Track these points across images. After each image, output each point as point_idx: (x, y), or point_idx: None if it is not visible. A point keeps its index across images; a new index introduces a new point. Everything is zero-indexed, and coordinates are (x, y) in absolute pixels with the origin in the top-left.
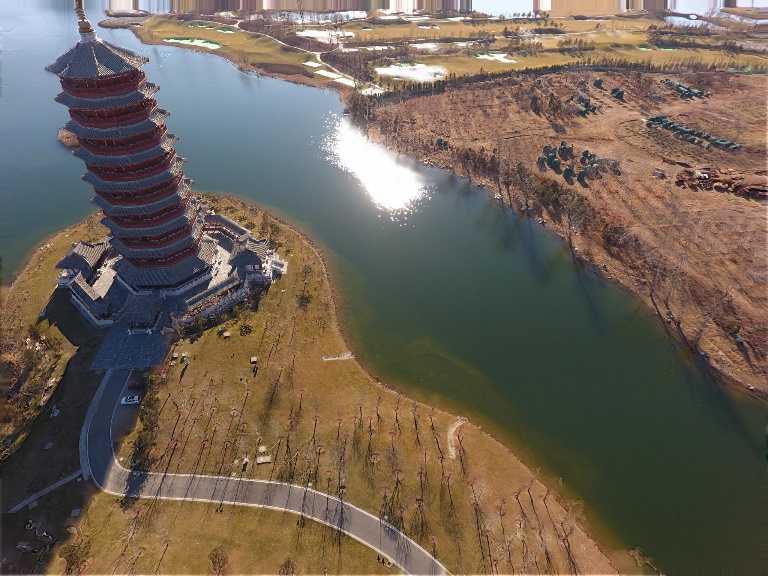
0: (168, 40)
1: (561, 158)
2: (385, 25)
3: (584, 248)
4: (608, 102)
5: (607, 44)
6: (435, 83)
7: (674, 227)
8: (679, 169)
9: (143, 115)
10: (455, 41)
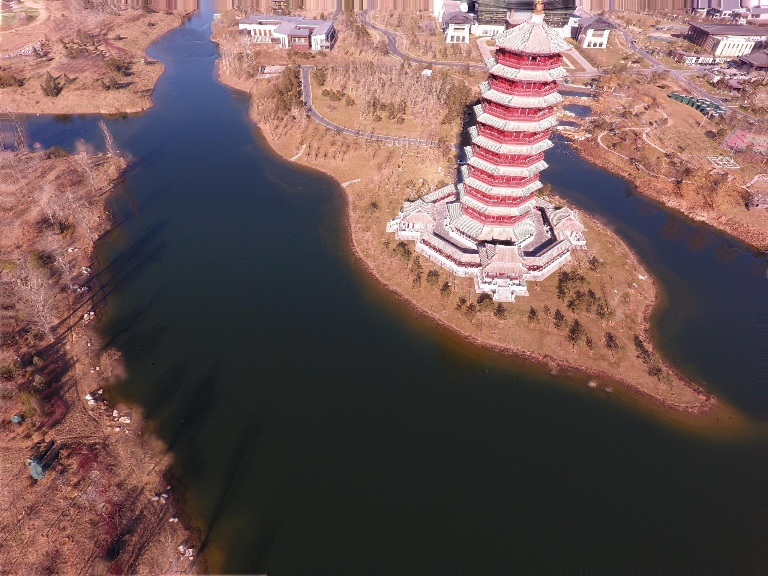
0: None
1: None
2: None
3: (90, 234)
4: None
5: None
6: None
7: None
8: None
9: None
10: None
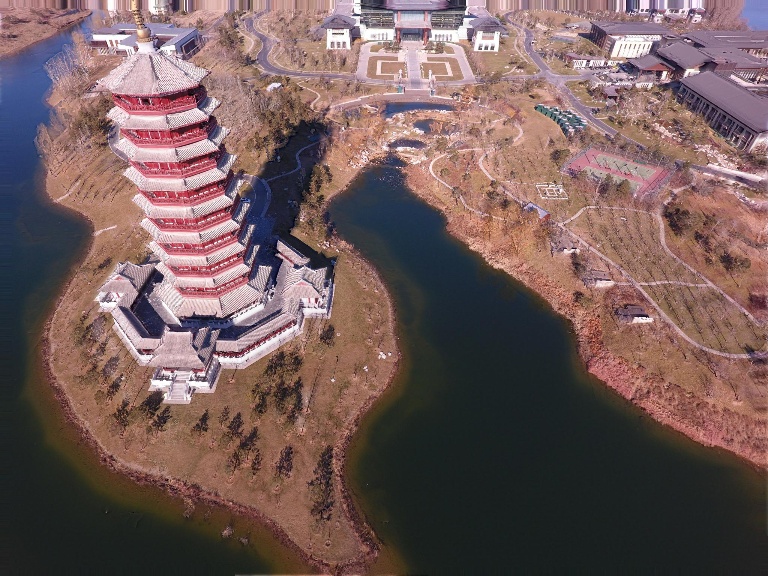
0: None
1: None
2: None
3: None
4: None
5: None
6: None
7: None
8: None
9: None
10: None
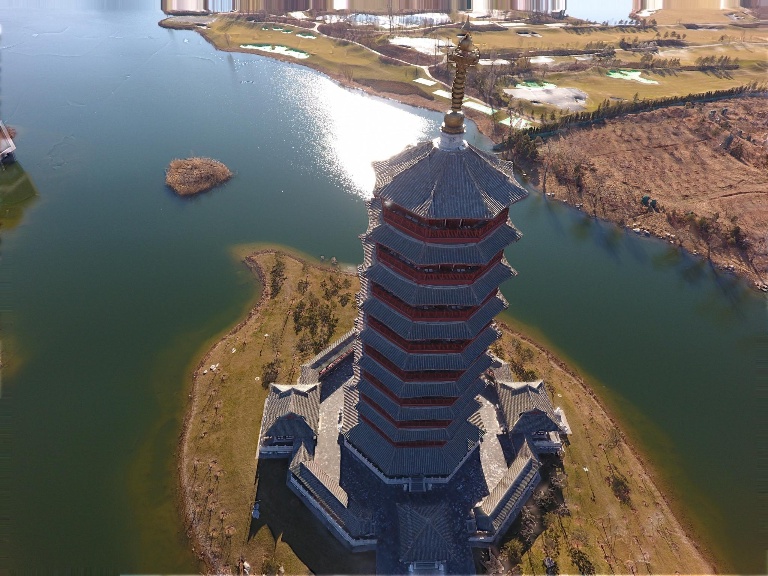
0: (245, 46)
1: None
2: (480, 32)
3: None
4: None
5: (752, 62)
6: (594, 113)
7: None
8: None
9: (497, 258)
10: (571, 54)
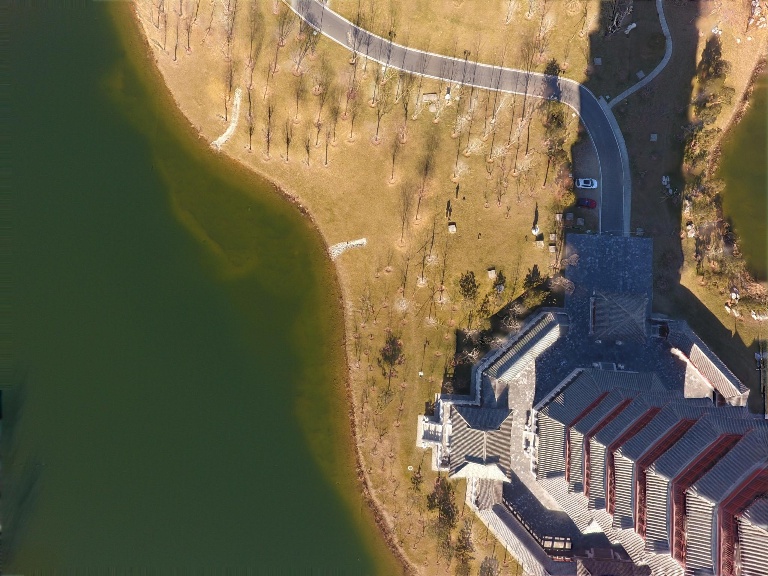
0: None
1: None
2: None
3: None
4: None
5: None
6: None
7: None
8: None
9: None
10: None
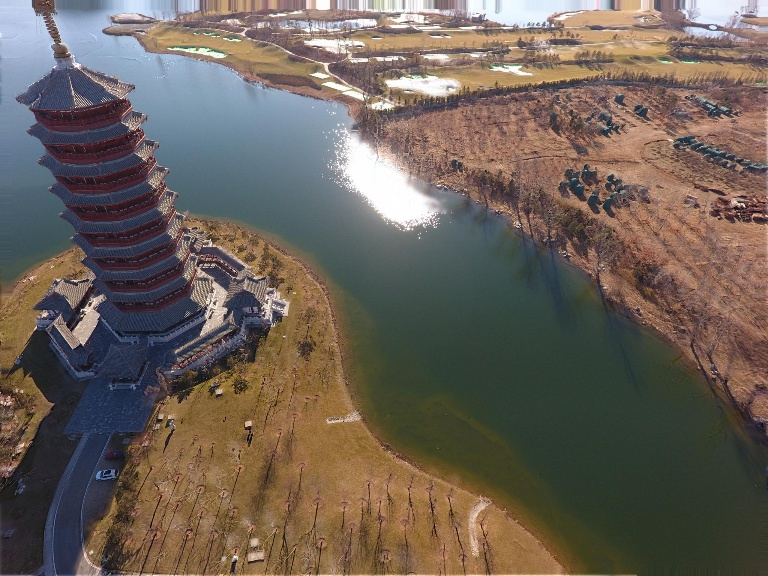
0: (173, 48)
1: (584, 183)
2: (395, 34)
3: (614, 287)
4: (631, 120)
5: (626, 56)
6: (448, 98)
7: (713, 265)
8: (713, 197)
9: (127, 149)
10: (468, 52)
